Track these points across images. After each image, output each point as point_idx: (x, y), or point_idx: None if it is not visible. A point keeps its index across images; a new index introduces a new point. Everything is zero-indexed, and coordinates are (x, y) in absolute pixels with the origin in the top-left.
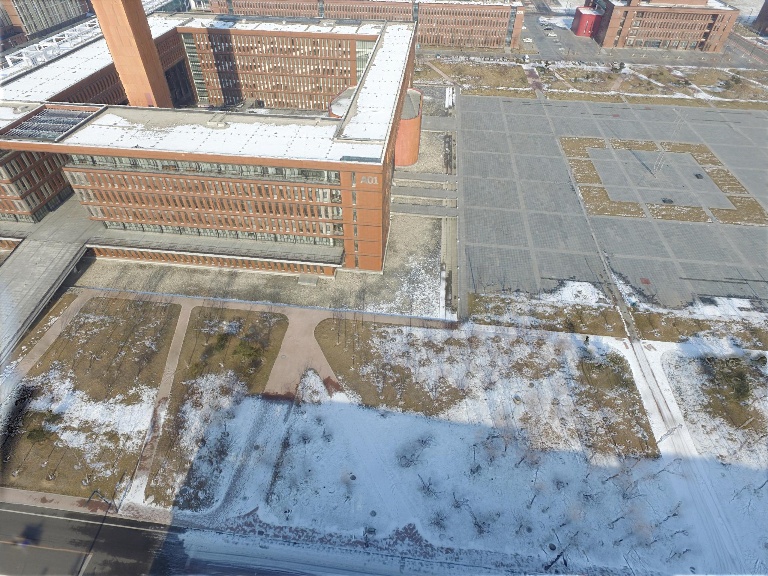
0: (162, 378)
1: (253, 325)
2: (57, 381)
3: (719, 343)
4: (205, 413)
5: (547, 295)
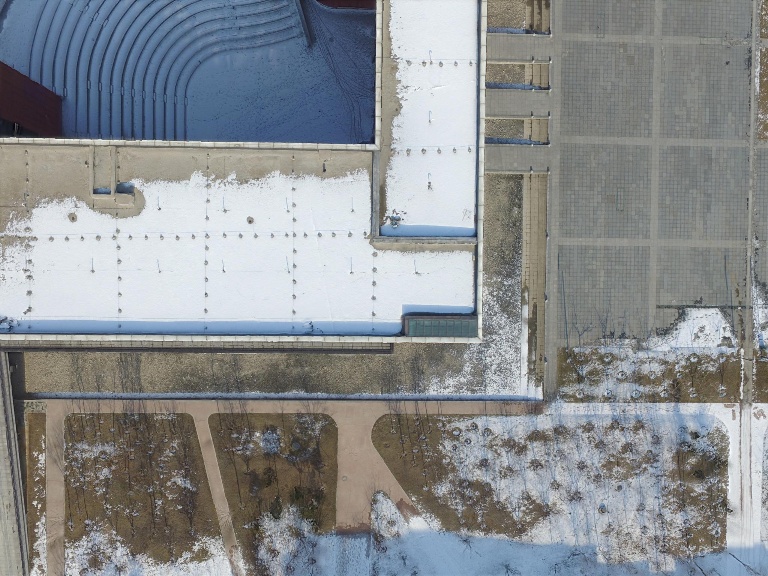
0: (219, 523)
1: (295, 438)
2: (107, 547)
3: None
4: (284, 560)
5: (659, 341)
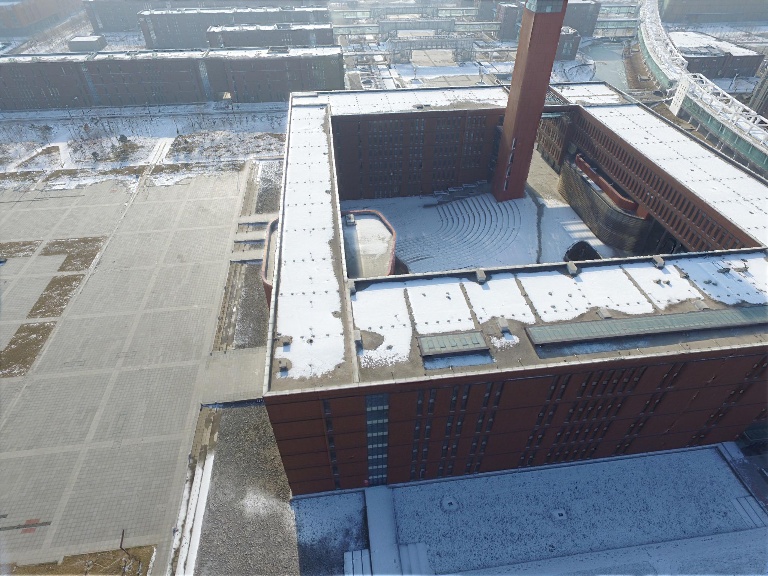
0: None
1: None
2: None
3: (103, 168)
4: None
5: (192, 176)
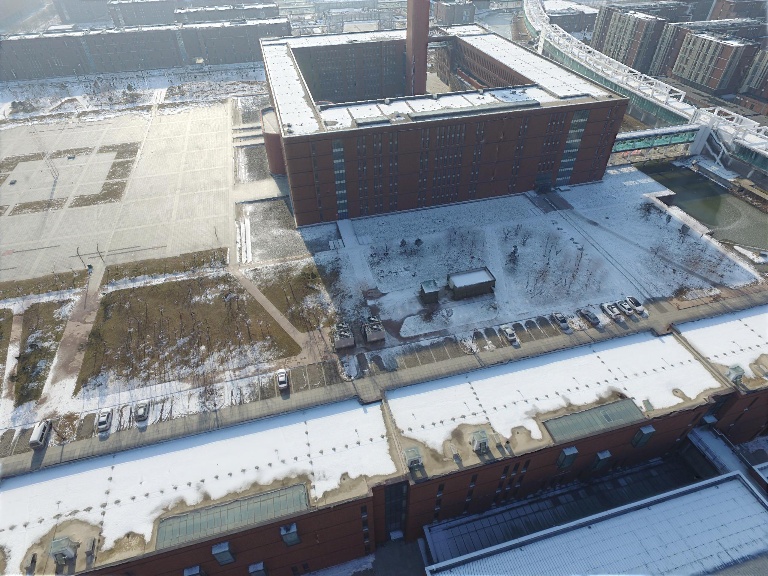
0: None
1: None
2: None
3: None
4: None
5: (189, 108)
